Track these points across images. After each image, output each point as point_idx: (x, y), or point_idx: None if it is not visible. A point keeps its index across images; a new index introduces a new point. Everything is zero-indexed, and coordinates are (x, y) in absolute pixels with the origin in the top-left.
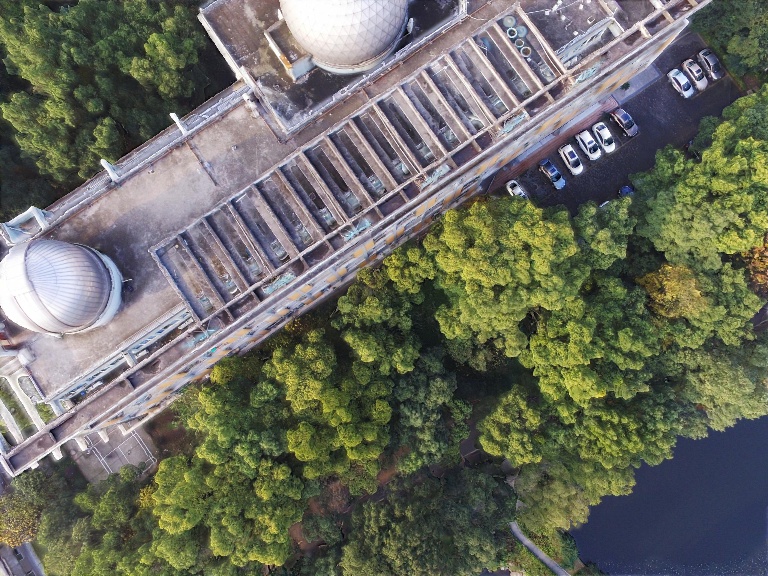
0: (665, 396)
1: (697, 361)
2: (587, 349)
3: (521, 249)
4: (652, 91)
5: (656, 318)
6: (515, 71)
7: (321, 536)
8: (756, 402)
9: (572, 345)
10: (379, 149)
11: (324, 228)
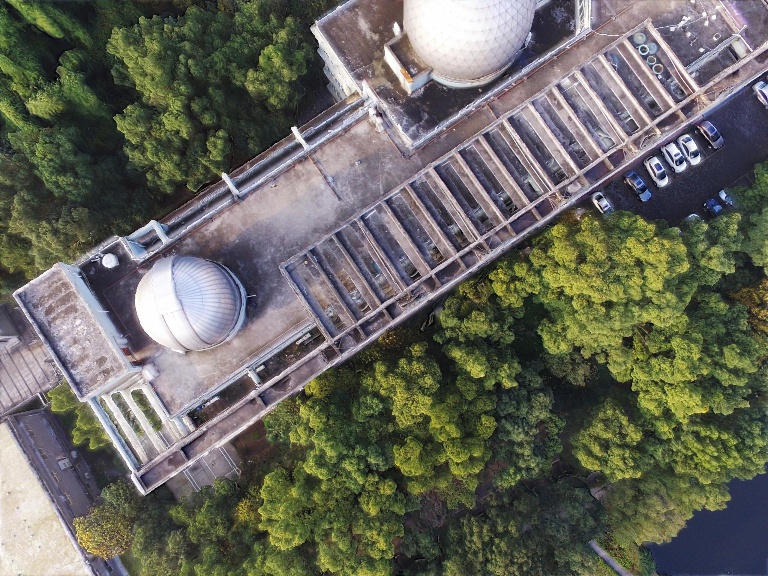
0: (760, 411)
1: None
2: (693, 365)
3: (633, 265)
4: (736, 103)
5: (757, 334)
6: (645, 88)
7: (420, 551)
8: None
9: (680, 361)
10: (509, 166)
11: (455, 245)
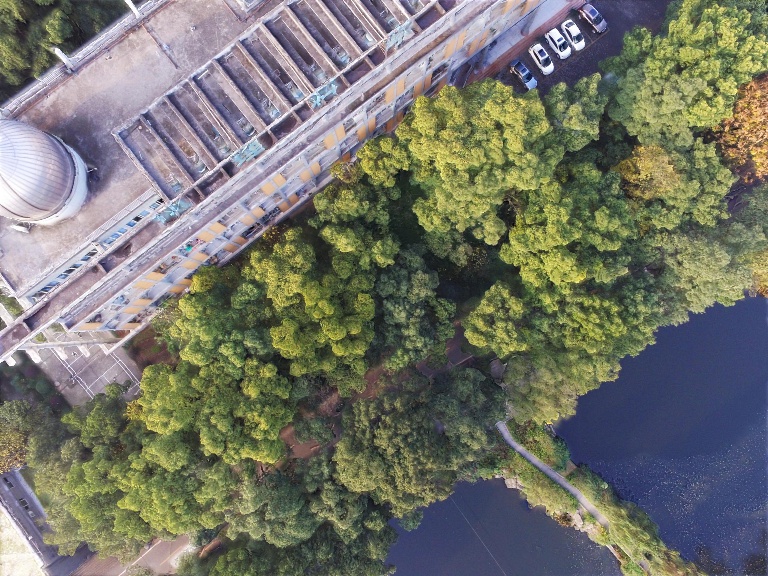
0: (645, 281)
1: (674, 243)
2: (565, 230)
3: (493, 128)
4: None
5: (632, 199)
6: None
7: (312, 437)
8: (732, 275)
9: (550, 225)
10: (341, 17)
11: (290, 100)
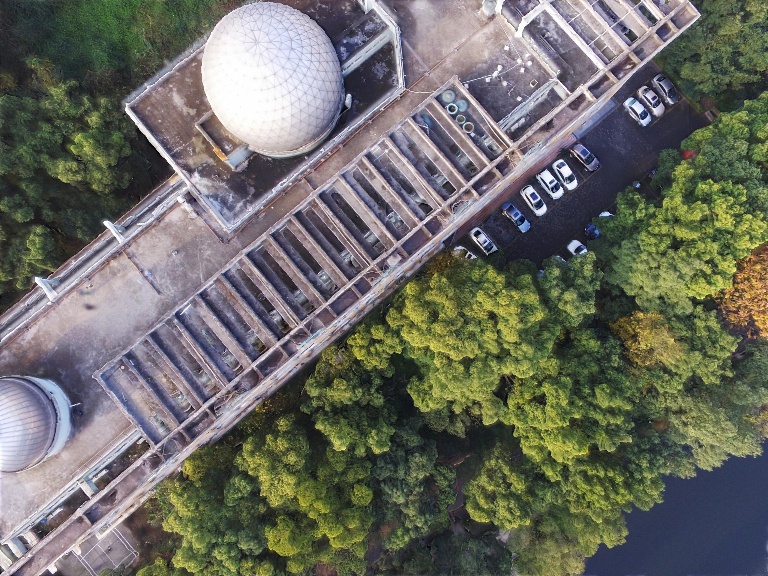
0: (649, 440)
1: (678, 403)
2: (565, 410)
3: (487, 319)
4: (610, 122)
5: (632, 367)
6: (459, 148)
7: None
8: (740, 443)
9: (549, 409)
10: (325, 244)
11: (276, 333)
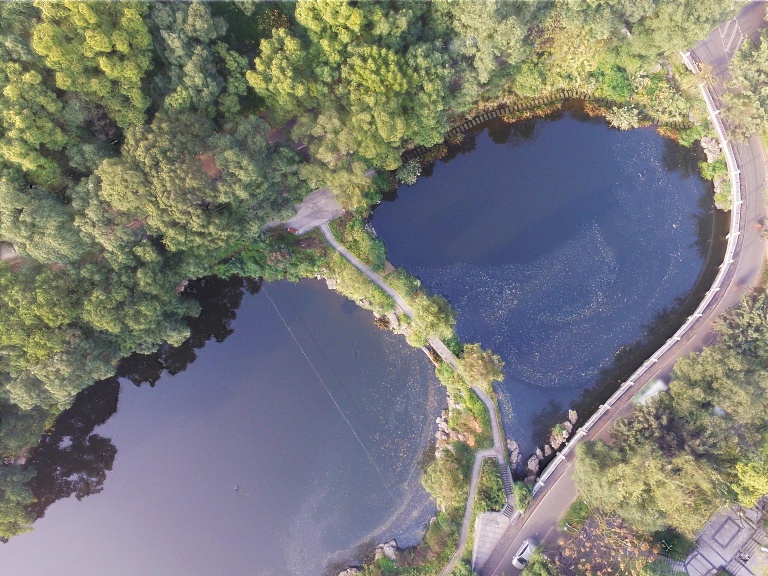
0: (433, 45)
1: (460, 7)
2: None
3: None
4: None
5: None
6: None
7: (87, 164)
8: (503, 25)
9: None
10: None
11: None
